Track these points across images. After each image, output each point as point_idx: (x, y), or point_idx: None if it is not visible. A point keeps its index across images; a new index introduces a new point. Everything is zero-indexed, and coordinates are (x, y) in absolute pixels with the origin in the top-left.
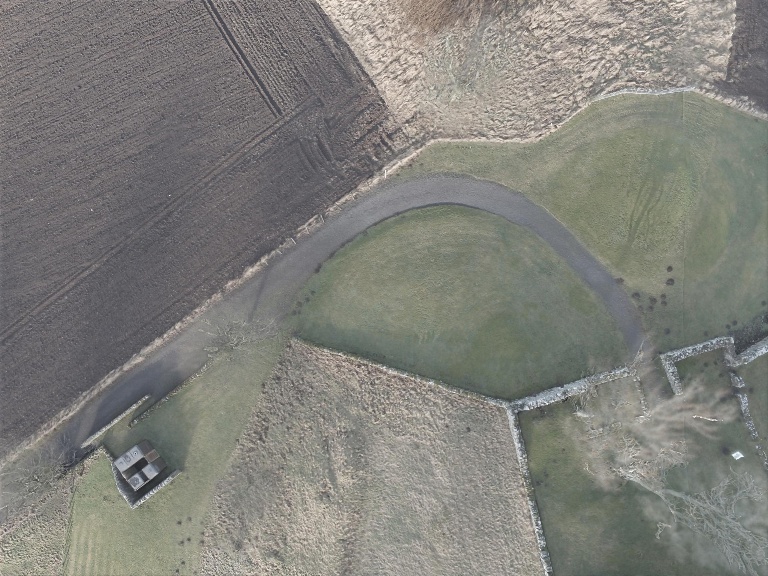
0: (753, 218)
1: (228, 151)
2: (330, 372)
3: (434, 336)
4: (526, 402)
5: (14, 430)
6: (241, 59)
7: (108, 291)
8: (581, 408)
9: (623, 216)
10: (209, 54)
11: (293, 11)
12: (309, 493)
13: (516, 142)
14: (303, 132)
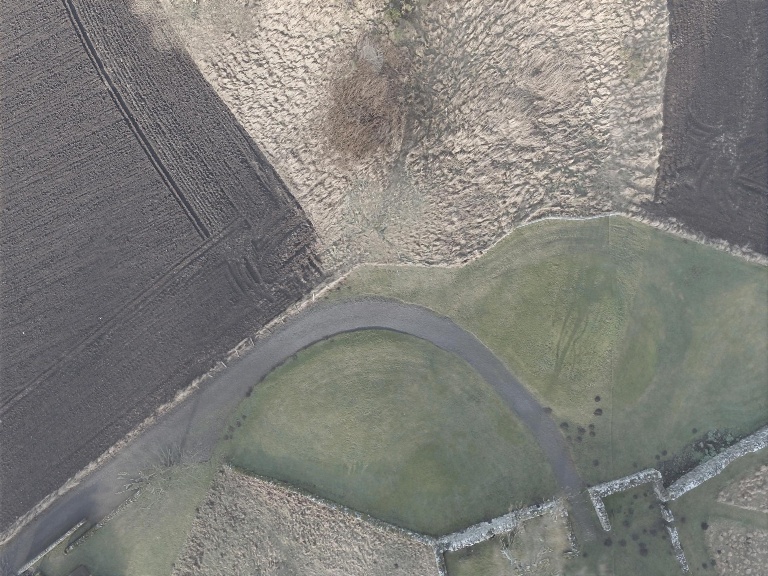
0: (682, 343)
1: (157, 273)
2: (262, 499)
3: (363, 467)
4: (451, 542)
5: None
6: (167, 181)
7: (42, 415)
8: (508, 546)
9: (550, 345)
10: (135, 176)
11: (217, 133)
12: None
13: (442, 267)
14: (231, 254)
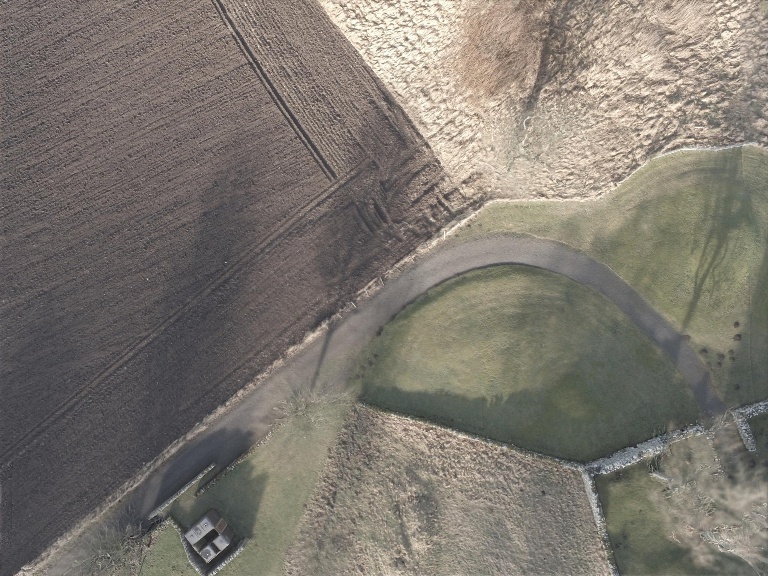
0: None
1: (283, 216)
2: (397, 436)
3: (503, 399)
4: (602, 465)
5: (78, 503)
6: (293, 124)
7: (167, 360)
8: (656, 468)
9: (688, 273)
10: (260, 120)
11: (345, 75)
12: (383, 559)
13: (576, 201)
14: (359, 195)
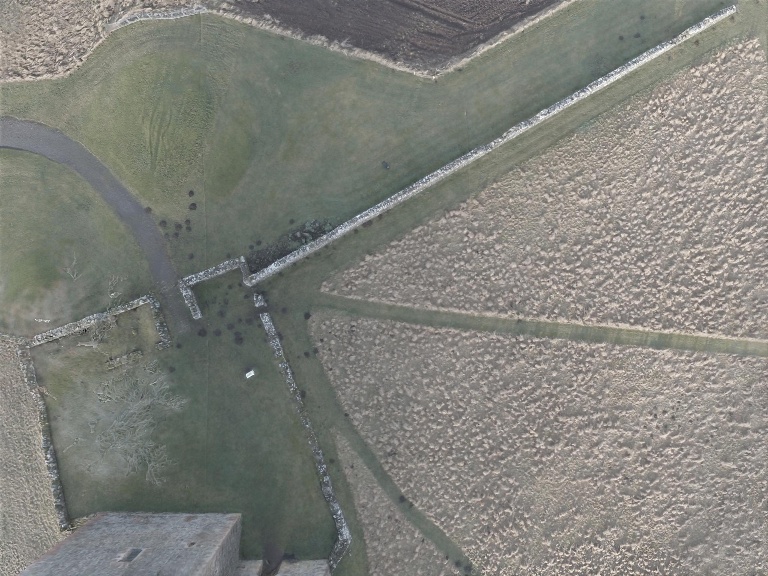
0: (278, 137)
1: None
2: None
3: None
4: None
5: None
6: None
7: None
8: (97, 339)
9: (144, 144)
10: None
11: None
12: None
13: (49, 79)
14: None
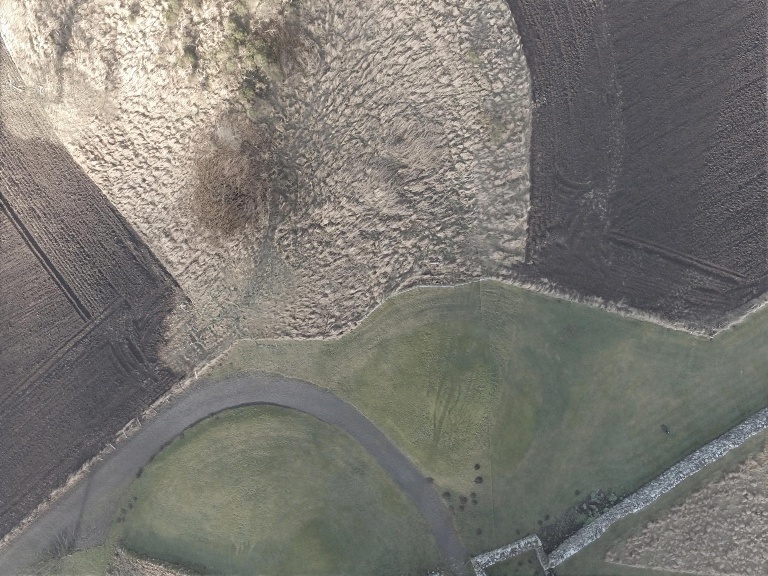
0: (560, 405)
1: (41, 358)
2: None
3: (250, 547)
4: None
5: None
6: (46, 265)
7: None
8: None
9: (426, 415)
10: (14, 261)
11: (91, 215)
12: None
13: (319, 340)
14: (114, 335)
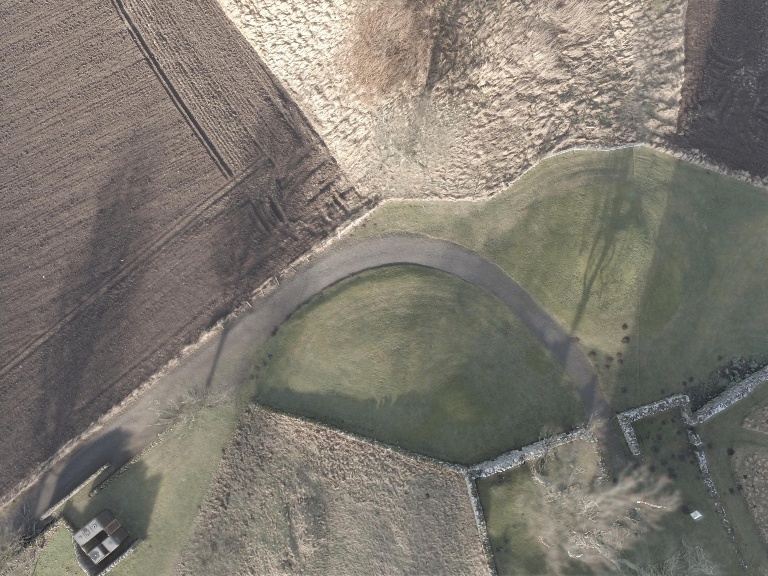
0: (707, 272)
1: (180, 214)
2: (289, 437)
3: (391, 400)
4: (483, 468)
5: None
6: (189, 121)
7: (63, 359)
8: (539, 472)
9: (577, 275)
10: (157, 116)
11: (240, 71)
12: (271, 561)
13: (468, 201)
14: (255, 193)
